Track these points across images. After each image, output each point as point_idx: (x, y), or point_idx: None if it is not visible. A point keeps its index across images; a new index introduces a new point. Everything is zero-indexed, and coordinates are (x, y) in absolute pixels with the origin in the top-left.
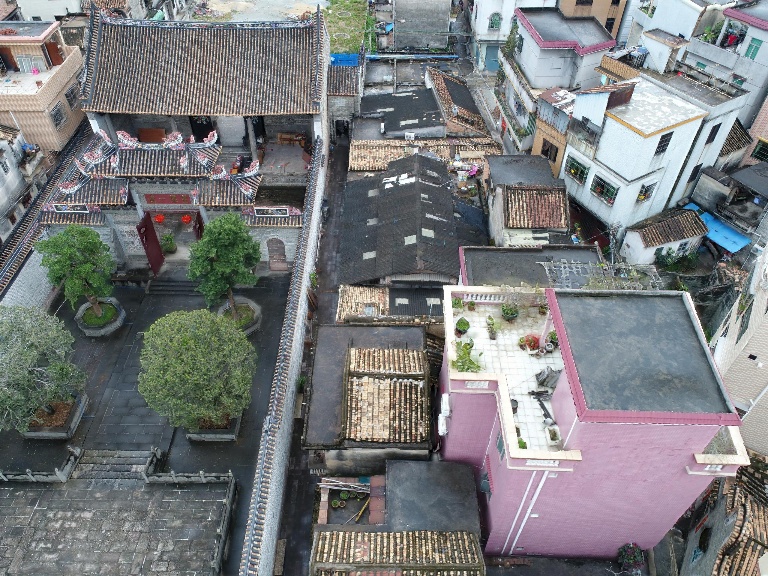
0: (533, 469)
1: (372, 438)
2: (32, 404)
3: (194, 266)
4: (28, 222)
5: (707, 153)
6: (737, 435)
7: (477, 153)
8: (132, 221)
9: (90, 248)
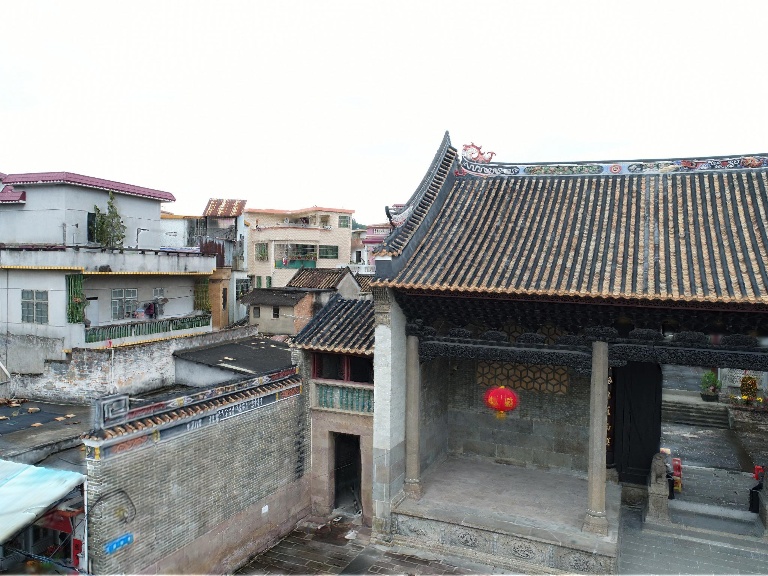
0: None
1: None
2: None
3: None
4: None
5: None
6: None
7: None
8: None
9: None
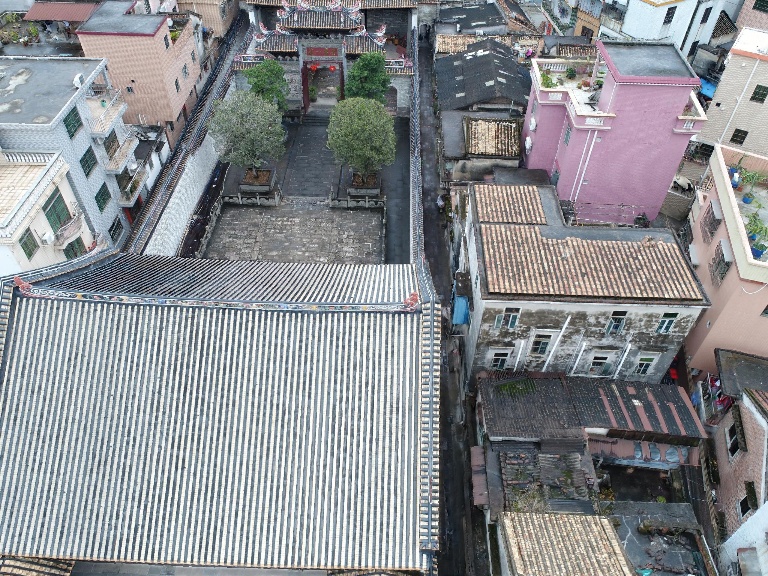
0: (589, 127)
1: (485, 152)
2: (264, 148)
3: (351, 84)
4: (217, 73)
5: (702, 32)
6: (702, 111)
7: (532, 42)
8: (294, 70)
9: (277, 76)
